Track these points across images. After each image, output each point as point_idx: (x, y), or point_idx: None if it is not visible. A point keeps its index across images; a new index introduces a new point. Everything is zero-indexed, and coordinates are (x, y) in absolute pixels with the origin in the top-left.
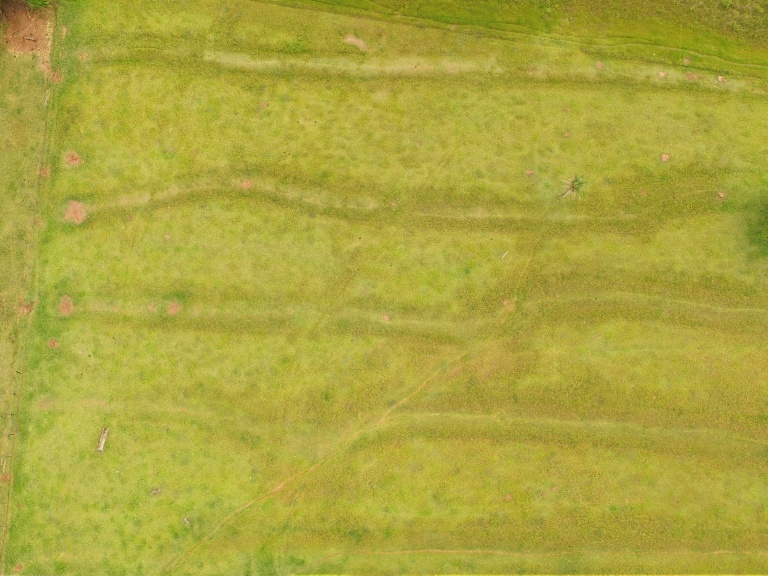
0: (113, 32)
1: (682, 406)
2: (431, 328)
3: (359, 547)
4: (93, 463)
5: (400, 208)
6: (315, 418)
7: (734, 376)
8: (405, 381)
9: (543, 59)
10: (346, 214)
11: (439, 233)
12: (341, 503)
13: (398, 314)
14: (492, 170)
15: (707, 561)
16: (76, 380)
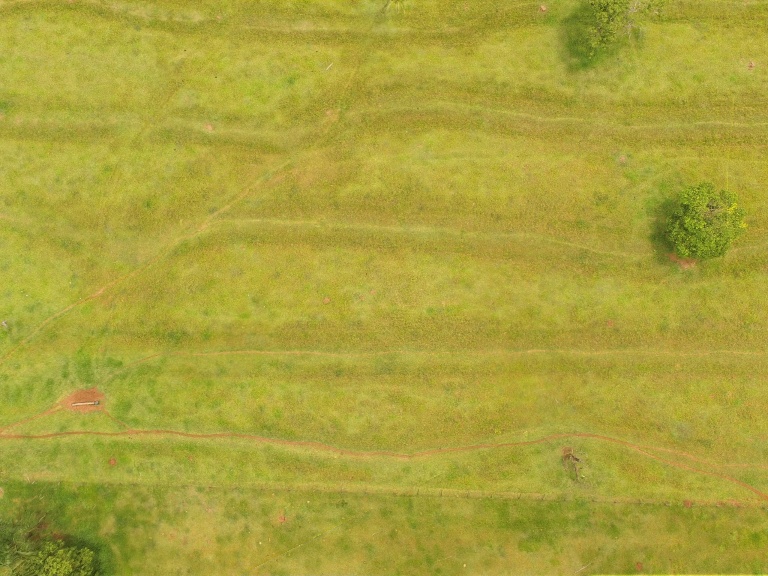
0: None
1: (500, 212)
2: (254, 137)
3: (177, 349)
4: None
5: (226, 21)
6: (136, 225)
7: (552, 183)
8: (227, 189)
9: None
10: (172, 27)
11: (264, 46)
12: (161, 307)
13: (221, 123)
14: None
15: (520, 359)
16: None
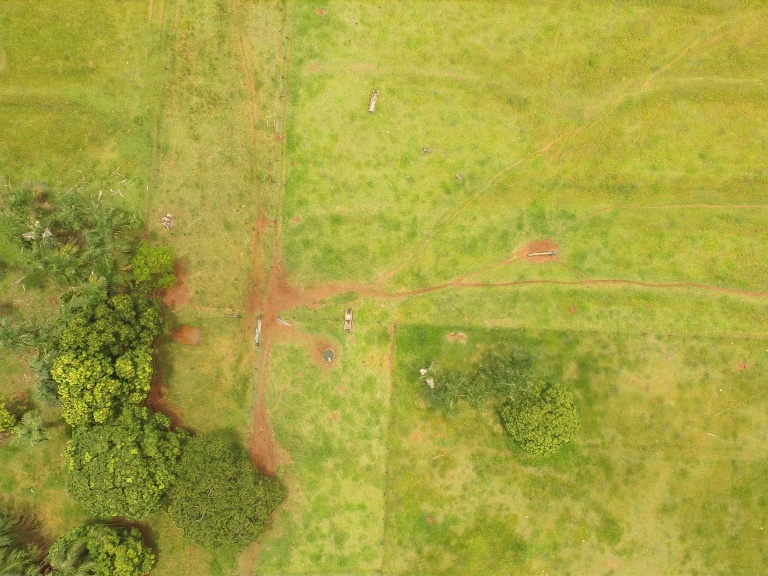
0: None
1: None
2: None
3: (628, 202)
4: (364, 124)
5: None
6: (580, 83)
7: None
8: (667, 48)
9: None
10: None
11: None
12: (608, 162)
13: None
14: None
15: None
16: (344, 46)
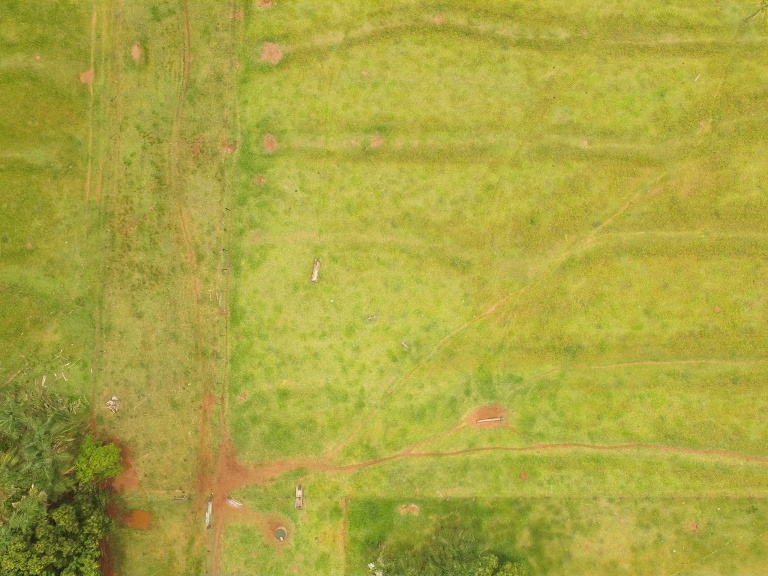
0: None
1: None
2: (630, 151)
3: (575, 362)
4: (307, 294)
5: (592, 37)
6: (522, 242)
7: None
8: (608, 203)
9: None
10: (539, 45)
11: (631, 59)
12: (554, 322)
13: (597, 138)
14: None
15: None
16: (285, 215)
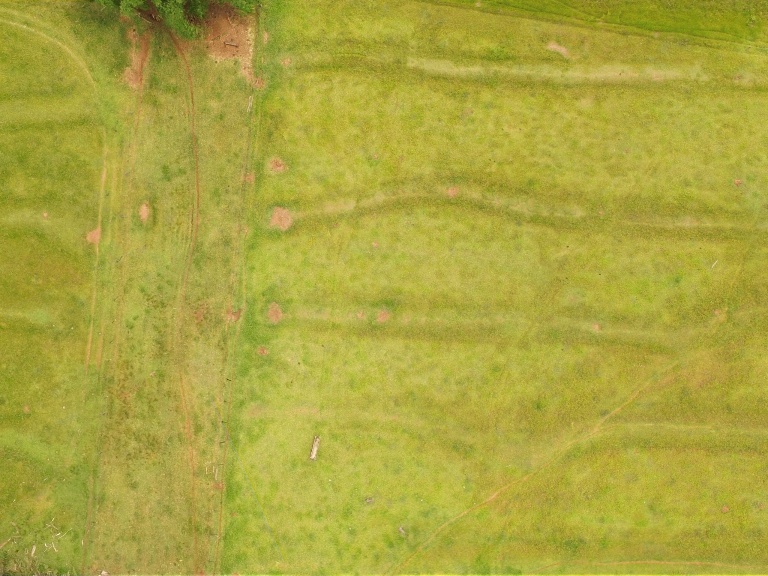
0: (315, 38)
1: None
2: (642, 338)
3: (576, 558)
4: (305, 471)
5: (608, 216)
6: (527, 427)
7: None
8: (617, 391)
9: (748, 67)
10: (553, 222)
11: (647, 242)
12: (556, 513)
13: (609, 323)
14: (700, 179)
15: None
16: (286, 388)
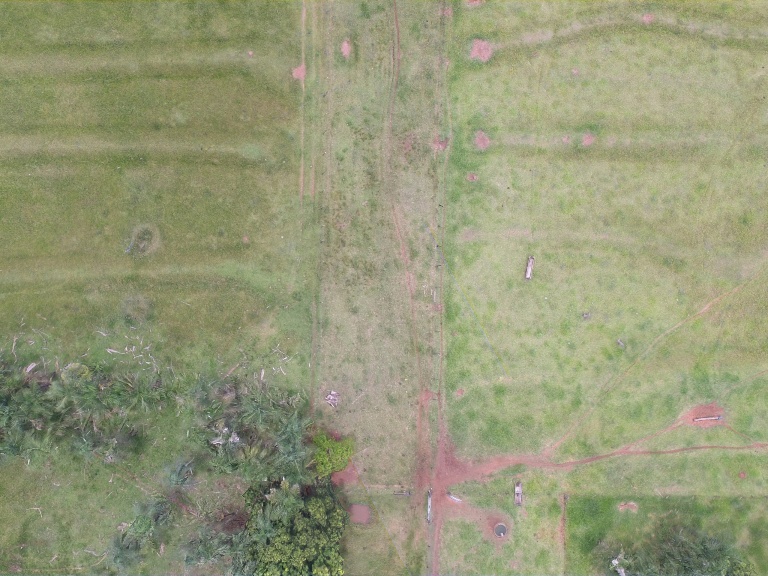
0: None
1: None
2: None
3: None
4: (522, 291)
5: None
6: (735, 241)
7: None
8: None
9: None
10: (748, 44)
11: None
12: None
13: None
14: None
15: None
16: (497, 212)
